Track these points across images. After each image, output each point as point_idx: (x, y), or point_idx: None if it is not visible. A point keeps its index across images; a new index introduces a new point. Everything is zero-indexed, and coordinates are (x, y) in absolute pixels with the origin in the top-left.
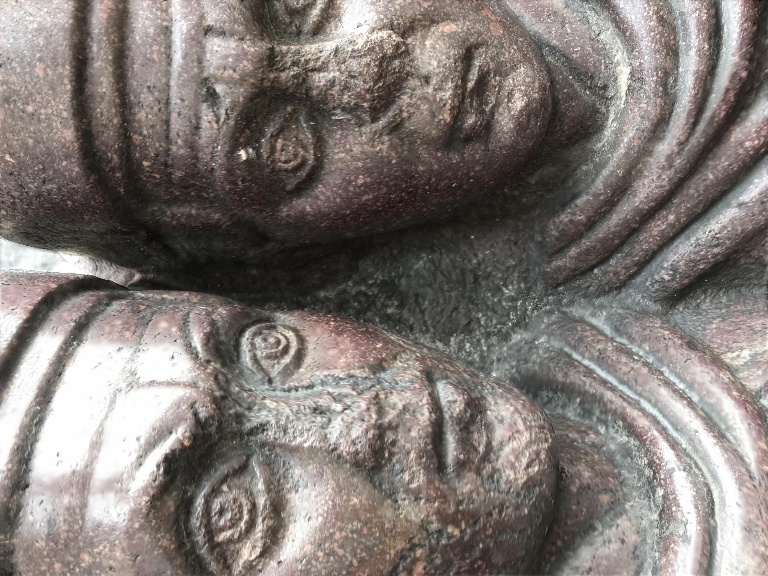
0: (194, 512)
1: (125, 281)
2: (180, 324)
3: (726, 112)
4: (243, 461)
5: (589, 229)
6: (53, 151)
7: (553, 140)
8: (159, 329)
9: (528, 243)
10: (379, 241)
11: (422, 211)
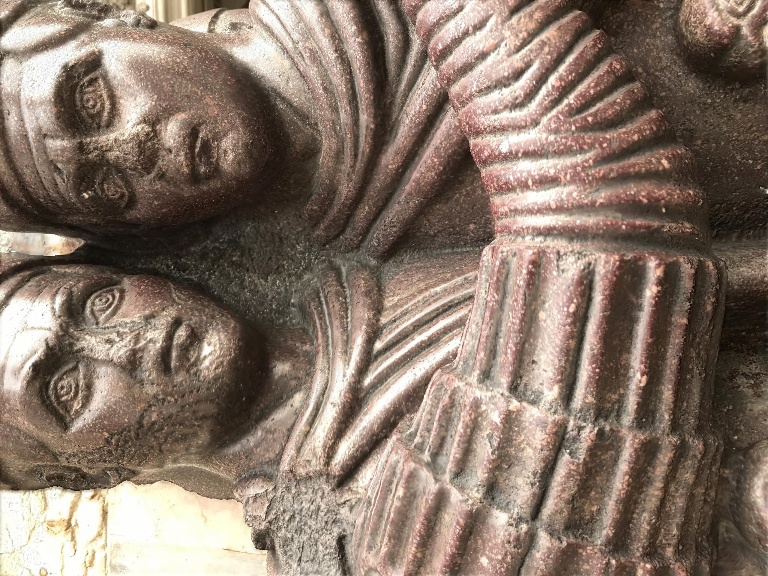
0: (50, 388)
1: None
2: (52, 295)
3: (370, 149)
4: (74, 365)
5: (325, 213)
6: None
7: (293, 158)
8: (42, 298)
9: None
10: (223, 214)
11: (206, 213)
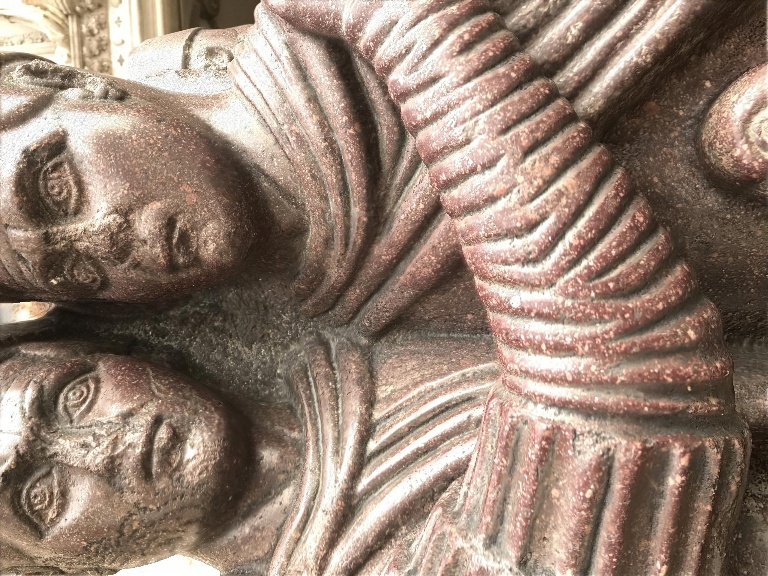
0: (22, 497)
1: None
2: (21, 392)
3: (362, 239)
4: (48, 471)
5: (313, 292)
6: None
7: (278, 236)
8: (11, 395)
9: None
10: None
11: None
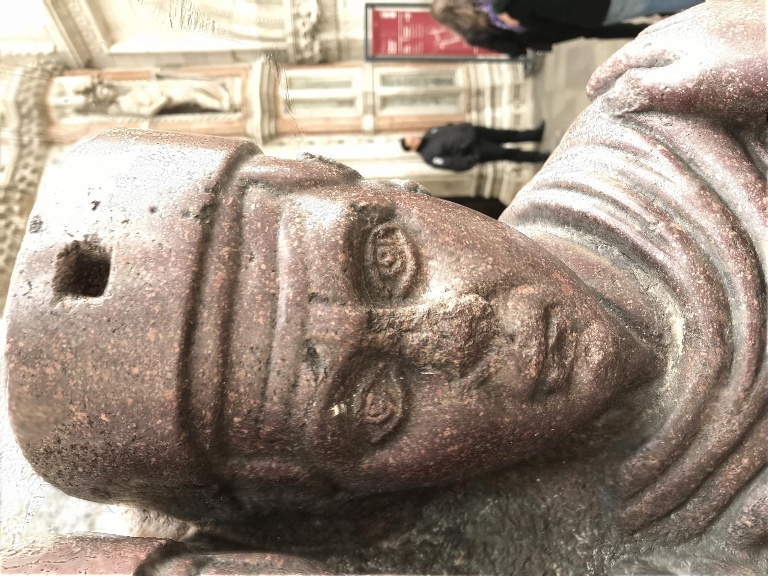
0: None
1: (177, 534)
2: None
3: None
4: None
5: (663, 473)
6: (150, 410)
7: None
8: None
9: (597, 486)
10: (442, 485)
11: (502, 460)
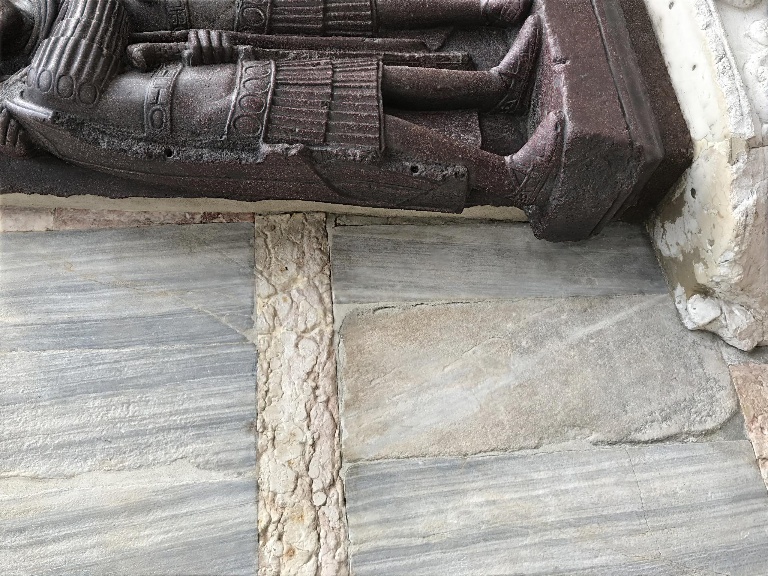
0: None
1: None
2: None
3: (50, 19)
4: None
5: (33, 48)
6: None
7: (24, 29)
8: None
9: None
10: None
11: None
